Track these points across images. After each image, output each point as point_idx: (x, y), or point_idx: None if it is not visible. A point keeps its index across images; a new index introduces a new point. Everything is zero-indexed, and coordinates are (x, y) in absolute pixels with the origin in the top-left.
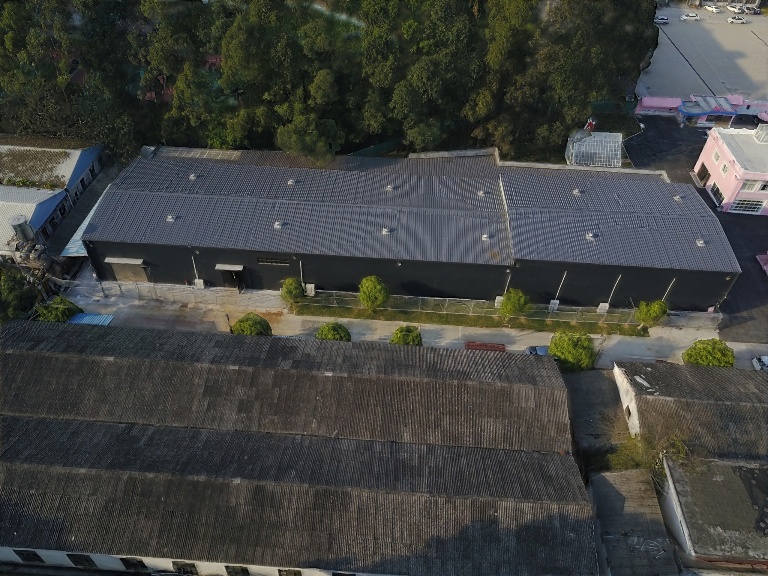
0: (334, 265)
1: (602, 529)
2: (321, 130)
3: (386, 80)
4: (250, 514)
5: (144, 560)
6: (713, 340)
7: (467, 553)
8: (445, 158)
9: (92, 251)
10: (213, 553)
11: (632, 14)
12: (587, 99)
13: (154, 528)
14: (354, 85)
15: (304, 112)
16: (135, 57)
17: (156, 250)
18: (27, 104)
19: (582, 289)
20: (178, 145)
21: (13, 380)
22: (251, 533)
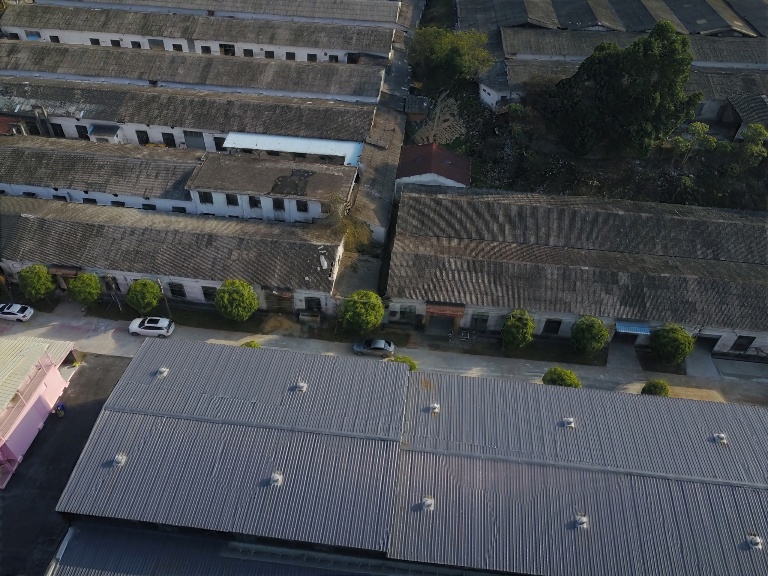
0: None
1: None
2: None
3: None
4: None
5: None
6: (229, 298)
7: None
8: None
9: None
10: None
11: None
12: None
13: None
14: None
15: None
16: None
17: None
18: None
19: None
20: None
21: None
22: None
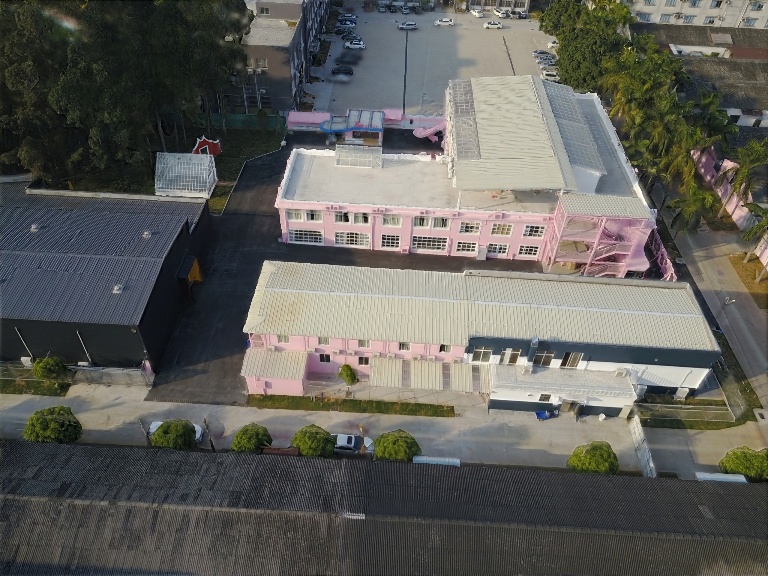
0: None
1: None
2: None
3: None
4: None
5: None
6: (54, 409)
7: None
8: None
9: None
10: None
11: (159, 25)
12: (103, 120)
13: None
14: None
15: None
16: None
17: None
18: None
19: None
20: None
21: None
22: None
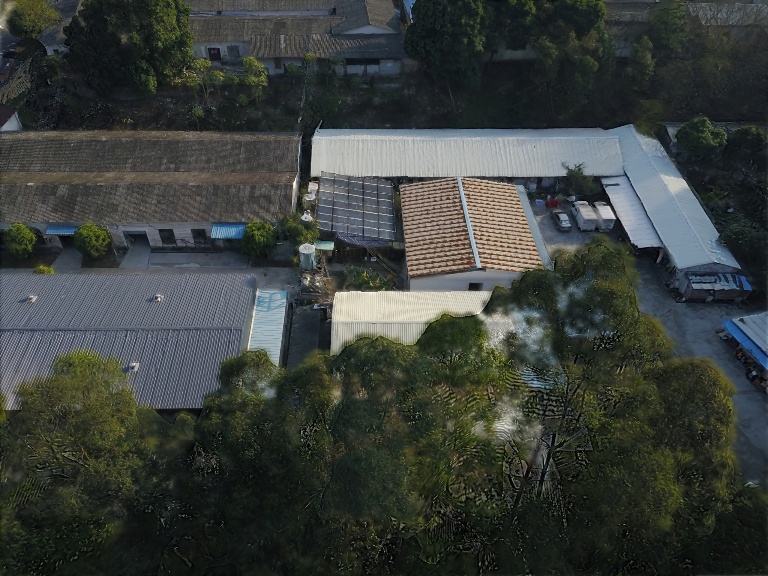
0: None
1: None
2: None
3: None
4: None
5: None
6: None
7: None
8: None
9: None
10: None
11: None
12: None
13: None
14: None
15: None
16: None
17: None
18: None
19: None
20: None
21: None
22: None
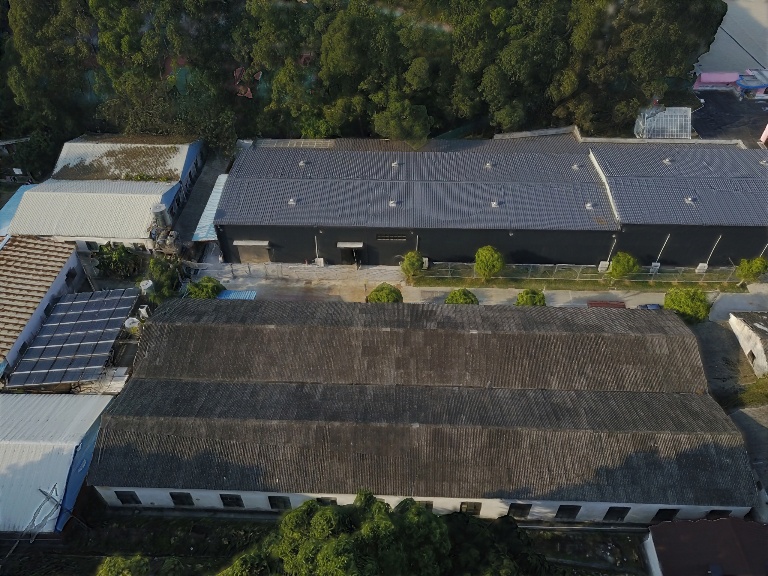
0: (449, 238)
1: (750, 457)
2: (413, 115)
3: (476, 65)
4: (433, 454)
5: (338, 499)
6: None
7: (635, 480)
8: (528, 138)
9: (221, 235)
10: (405, 488)
11: None
12: (665, 74)
13: (348, 469)
14: (443, 71)
15: (398, 99)
16: (239, 54)
17: (282, 231)
18: (134, 104)
19: (683, 251)
20: (270, 137)
21: (186, 349)
22: (436, 470)
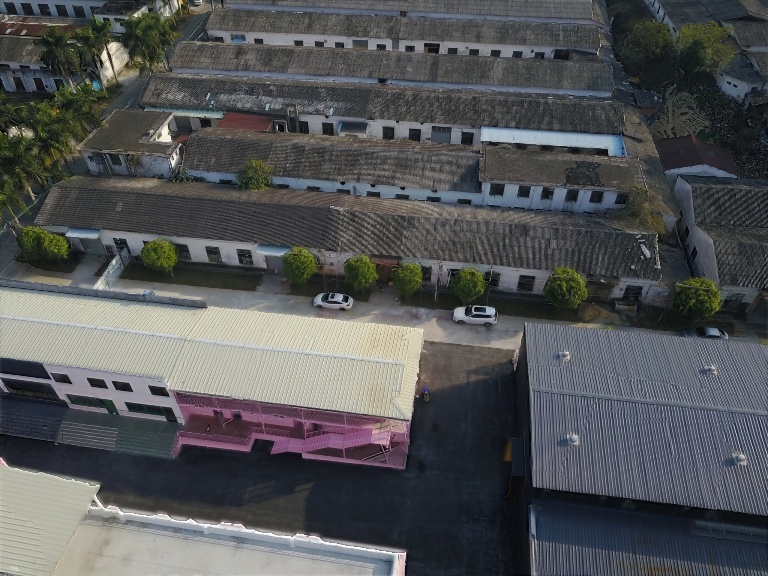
0: None
1: None
2: None
3: None
4: None
5: None
6: (567, 286)
7: None
8: None
9: None
10: None
11: None
12: None
13: None
14: None
15: None
16: None
17: None
18: None
19: None
20: None
21: None
22: None
